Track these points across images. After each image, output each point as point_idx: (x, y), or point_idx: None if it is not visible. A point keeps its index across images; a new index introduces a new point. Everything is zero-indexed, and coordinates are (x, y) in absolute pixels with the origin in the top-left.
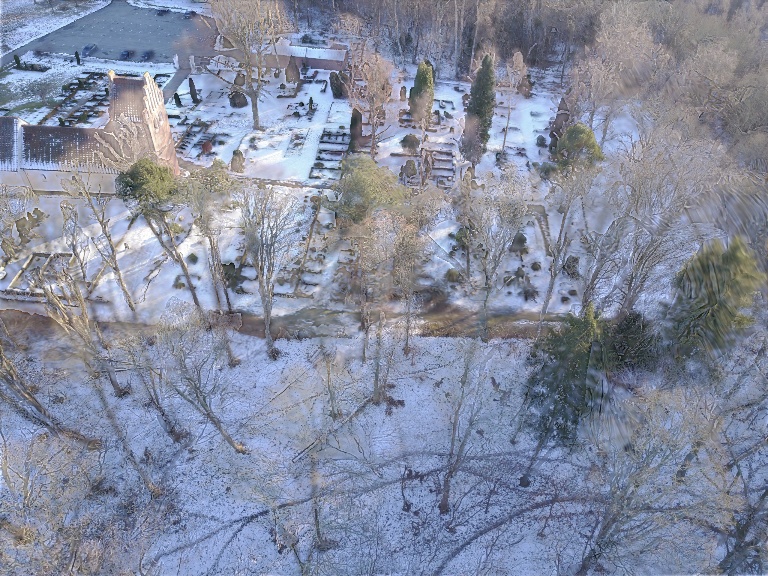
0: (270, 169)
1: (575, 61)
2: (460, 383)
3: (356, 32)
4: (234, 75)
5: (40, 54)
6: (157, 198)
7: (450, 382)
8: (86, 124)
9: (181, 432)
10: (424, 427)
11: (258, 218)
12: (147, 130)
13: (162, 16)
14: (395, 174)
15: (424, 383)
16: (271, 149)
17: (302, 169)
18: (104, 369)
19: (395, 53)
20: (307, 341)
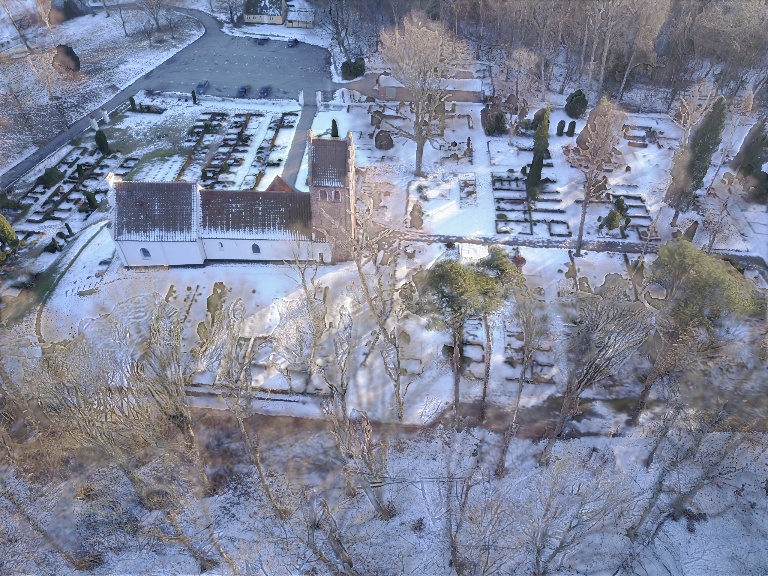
0: (451, 223)
1: (724, 82)
2: (764, 490)
3: (474, 56)
4: (365, 111)
5: (152, 94)
6: (473, 308)
7: (752, 489)
8: (229, 174)
9: (463, 562)
10: (737, 547)
11: (605, 332)
12: (347, 194)
13: (263, 45)
14: (589, 225)
15: (723, 491)
16: (443, 199)
17: (485, 222)
18: (359, 485)
19: (531, 80)
20: (576, 442)
